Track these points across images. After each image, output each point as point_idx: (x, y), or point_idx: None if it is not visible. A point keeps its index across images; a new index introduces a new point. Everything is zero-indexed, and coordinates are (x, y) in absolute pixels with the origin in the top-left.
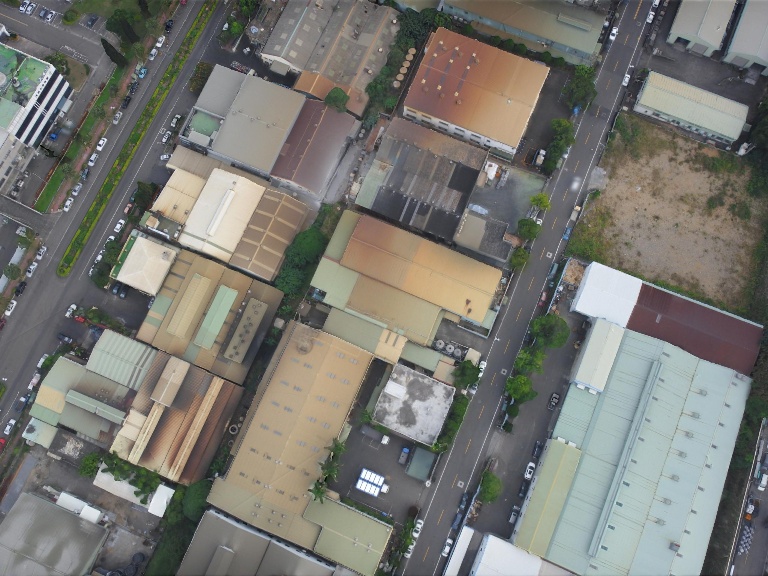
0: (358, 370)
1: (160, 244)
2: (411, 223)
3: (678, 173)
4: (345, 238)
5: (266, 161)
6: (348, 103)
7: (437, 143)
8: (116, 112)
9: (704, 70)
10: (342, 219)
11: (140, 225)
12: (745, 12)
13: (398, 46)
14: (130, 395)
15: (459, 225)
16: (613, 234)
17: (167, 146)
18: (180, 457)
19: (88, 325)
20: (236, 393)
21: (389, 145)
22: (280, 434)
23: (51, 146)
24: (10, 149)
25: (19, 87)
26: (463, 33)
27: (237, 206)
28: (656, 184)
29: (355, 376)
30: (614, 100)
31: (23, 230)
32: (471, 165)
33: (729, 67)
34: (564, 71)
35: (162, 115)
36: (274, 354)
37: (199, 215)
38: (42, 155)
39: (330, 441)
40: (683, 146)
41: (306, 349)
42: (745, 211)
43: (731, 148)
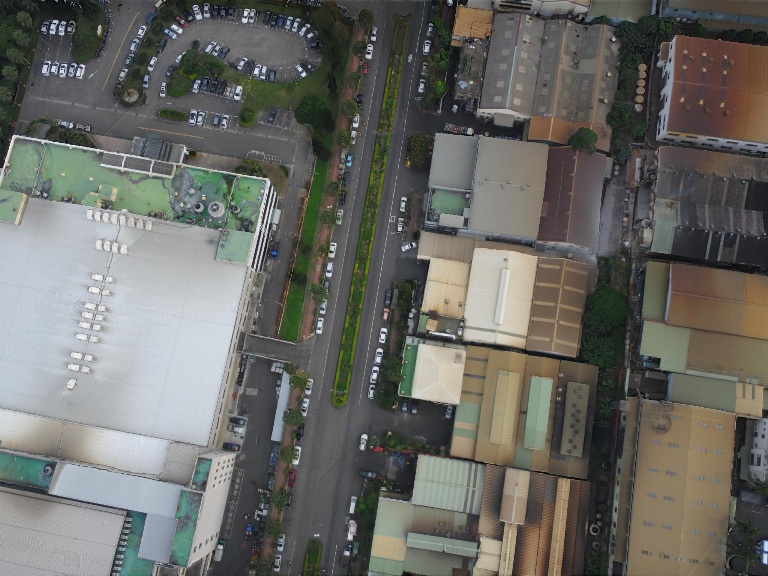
0: (726, 435)
1: (444, 346)
2: (719, 258)
3: None
4: (659, 293)
5: (531, 227)
6: None
7: (718, 164)
8: (336, 211)
9: None
10: (648, 273)
11: (418, 332)
12: None
13: (625, 65)
14: (471, 521)
15: None
16: None
17: (403, 235)
18: (552, 575)
19: (388, 453)
20: (585, 490)
21: (668, 179)
22: (670, 528)
23: (273, 265)
24: (248, 283)
25: (239, 212)
26: (693, 35)
27: (516, 284)
28: None
29: (726, 443)
30: None
31: (278, 366)
32: (764, 179)
33: None
34: None
35: (386, 202)
36: (624, 440)
37: (477, 304)
38: (267, 277)
39: (723, 521)
40: None
41: (664, 427)
42: None
43: None
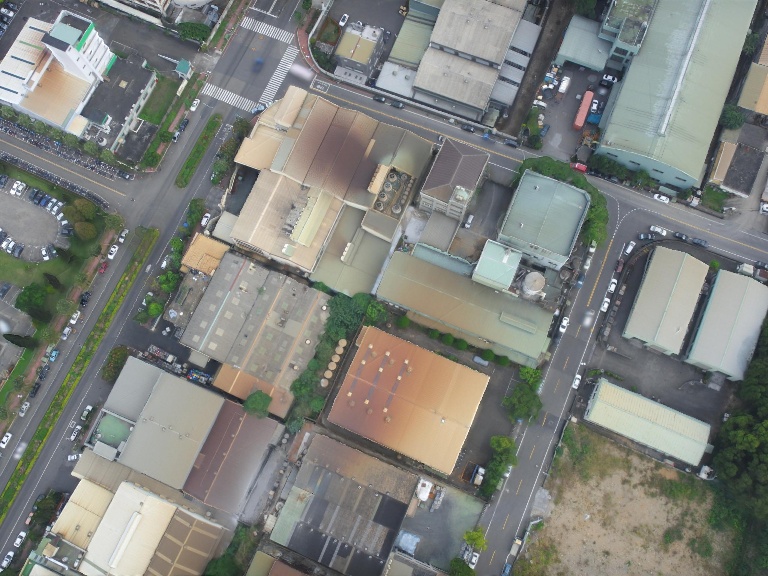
0: None
1: (59, 573)
2: (331, 565)
3: (632, 498)
4: None
5: (177, 477)
6: (270, 405)
7: (362, 468)
8: (23, 402)
9: (663, 370)
10: (254, 562)
11: (37, 553)
12: (708, 311)
13: (328, 336)
14: None
15: (383, 572)
16: (558, 572)
17: (76, 443)
18: None
19: None
20: None
21: (309, 470)
22: None
23: None
24: None
25: None
26: (398, 324)
27: (144, 531)
28: (607, 511)
29: None
30: (563, 405)
31: None
32: (399, 497)
33: (691, 368)
34: (509, 368)
35: (72, 405)
36: None
37: (102, 540)
38: None
39: None
40: (638, 465)
41: None
42: (706, 547)
43: (691, 469)
